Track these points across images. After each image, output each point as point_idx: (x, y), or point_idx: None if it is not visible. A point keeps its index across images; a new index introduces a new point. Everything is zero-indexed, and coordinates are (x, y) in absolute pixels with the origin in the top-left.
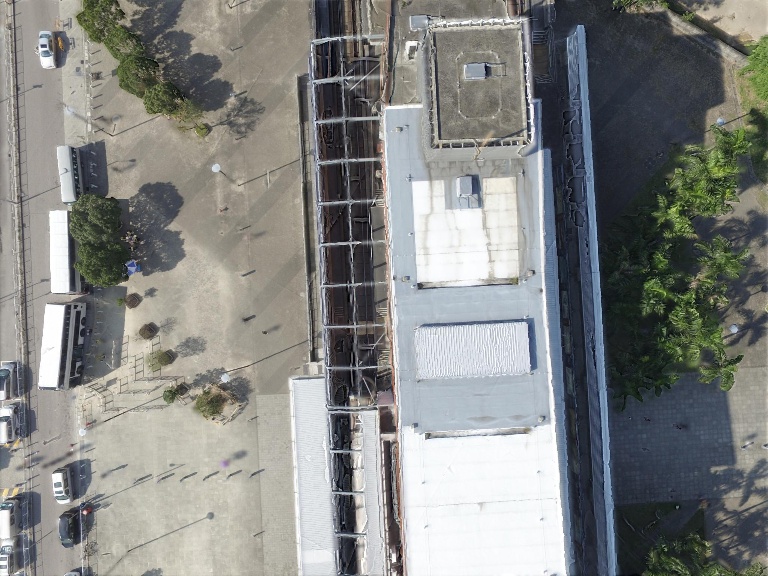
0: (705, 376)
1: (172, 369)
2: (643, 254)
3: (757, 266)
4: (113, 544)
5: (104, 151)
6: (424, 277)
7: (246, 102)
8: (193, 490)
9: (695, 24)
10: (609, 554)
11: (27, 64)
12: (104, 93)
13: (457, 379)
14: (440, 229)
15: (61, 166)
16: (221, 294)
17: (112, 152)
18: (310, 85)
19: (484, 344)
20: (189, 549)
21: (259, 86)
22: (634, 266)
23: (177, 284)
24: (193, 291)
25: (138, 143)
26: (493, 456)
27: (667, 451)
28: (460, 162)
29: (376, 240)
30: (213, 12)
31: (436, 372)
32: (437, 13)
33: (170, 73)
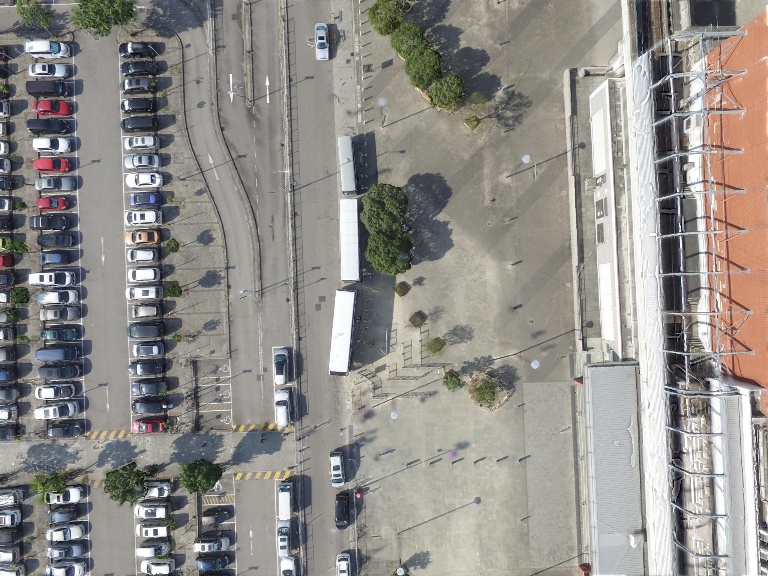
0: None
1: (440, 356)
2: None
3: None
4: (382, 527)
5: (374, 142)
6: None
7: (514, 95)
8: (460, 475)
9: None
10: None
11: (299, 55)
12: (374, 85)
13: None
14: None
15: (344, 156)
16: (488, 283)
17: (382, 143)
18: (578, 80)
19: None
20: (456, 533)
21: (526, 80)
22: None
23: (445, 273)
24: (461, 280)
25: (407, 134)
26: None
27: None
28: None
29: (688, 231)
30: (481, 7)
31: None
32: None
33: None
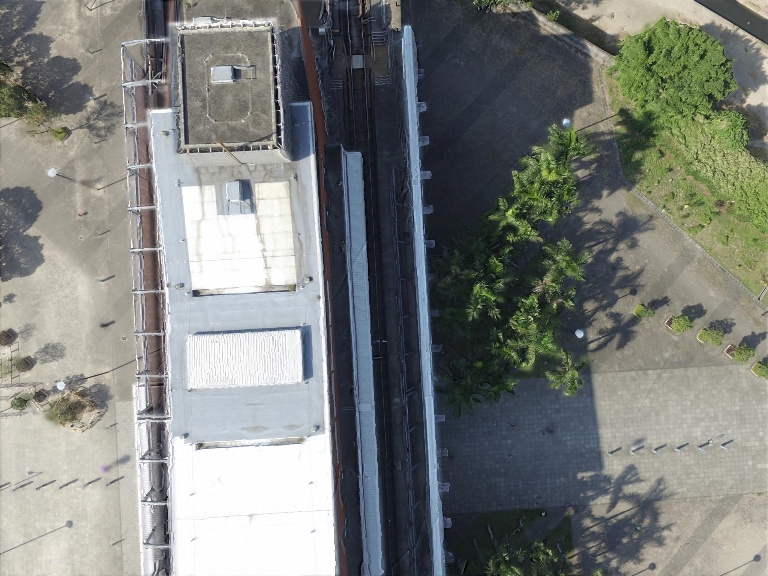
0: (554, 381)
1: (31, 376)
2: (480, 258)
3: (625, 269)
4: None
5: None
6: (199, 284)
7: (106, 105)
8: (52, 498)
9: (573, 24)
10: (435, 564)
11: None
12: None
13: (230, 388)
14: (213, 235)
15: None
16: (80, 300)
17: None
18: None
19: (266, 352)
20: (48, 558)
21: (119, 89)
22: (466, 270)
23: (36, 290)
24: (52, 297)
25: None
26: (265, 467)
27: (533, 457)
28: (230, 167)
29: None
30: (73, 14)
31: (210, 381)
32: (223, 15)
33: (29, 76)
